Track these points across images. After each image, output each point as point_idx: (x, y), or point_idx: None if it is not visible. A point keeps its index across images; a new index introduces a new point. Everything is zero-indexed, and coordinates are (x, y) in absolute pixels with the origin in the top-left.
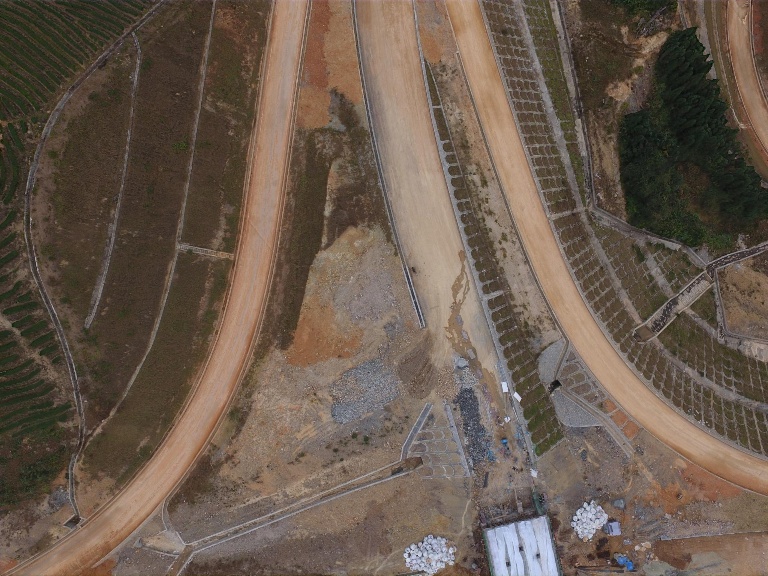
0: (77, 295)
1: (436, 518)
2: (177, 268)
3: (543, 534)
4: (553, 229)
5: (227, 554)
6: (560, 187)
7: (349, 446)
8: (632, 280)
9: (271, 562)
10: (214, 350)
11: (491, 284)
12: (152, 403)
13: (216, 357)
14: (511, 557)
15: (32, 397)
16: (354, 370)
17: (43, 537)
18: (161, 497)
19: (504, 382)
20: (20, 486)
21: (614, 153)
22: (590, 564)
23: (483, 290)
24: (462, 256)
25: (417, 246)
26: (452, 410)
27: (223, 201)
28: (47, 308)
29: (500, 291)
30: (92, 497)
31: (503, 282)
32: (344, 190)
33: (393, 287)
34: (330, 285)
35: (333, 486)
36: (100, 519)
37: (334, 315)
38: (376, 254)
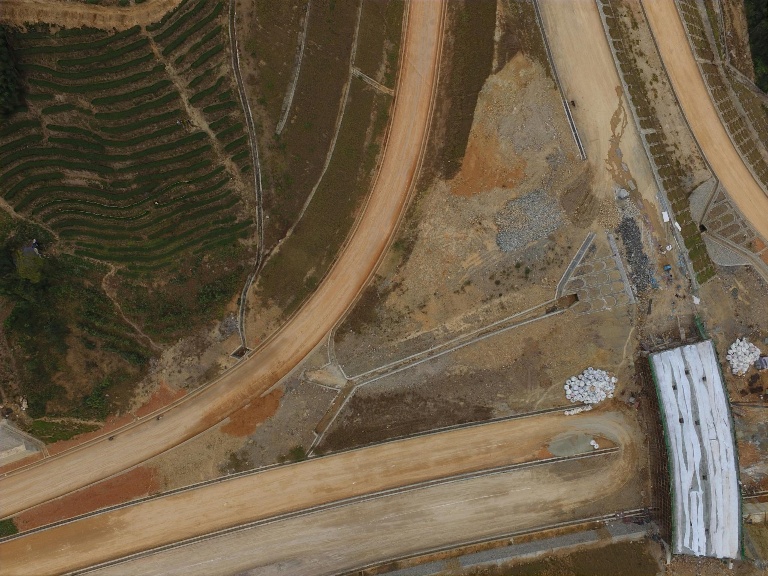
0: (271, 99)
1: (594, 352)
2: (351, 91)
3: (708, 358)
4: (701, 71)
5: (388, 389)
6: (701, 37)
7: (510, 279)
8: (766, 135)
9: (433, 395)
10: (376, 184)
11: (646, 121)
12: (322, 230)
13: (378, 191)
14: (677, 380)
15: (218, 209)
16: (518, 200)
17: (211, 367)
18: (327, 328)
19: (665, 212)
20: (196, 308)
21: (742, 15)
22: (743, 400)
23: (640, 124)
24: (619, 91)
25: (575, 81)
26: (614, 239)
27: (385, 36)
28: (244, 109)
29: (653, 130)
30: (260, 326)
31: (655, 121)
32: (509, 19)
33: (554, 120)
34: (494, 115)
35: (491, 322)
36: (266, 350)
37: (498, 145)
38: (538, 86)
